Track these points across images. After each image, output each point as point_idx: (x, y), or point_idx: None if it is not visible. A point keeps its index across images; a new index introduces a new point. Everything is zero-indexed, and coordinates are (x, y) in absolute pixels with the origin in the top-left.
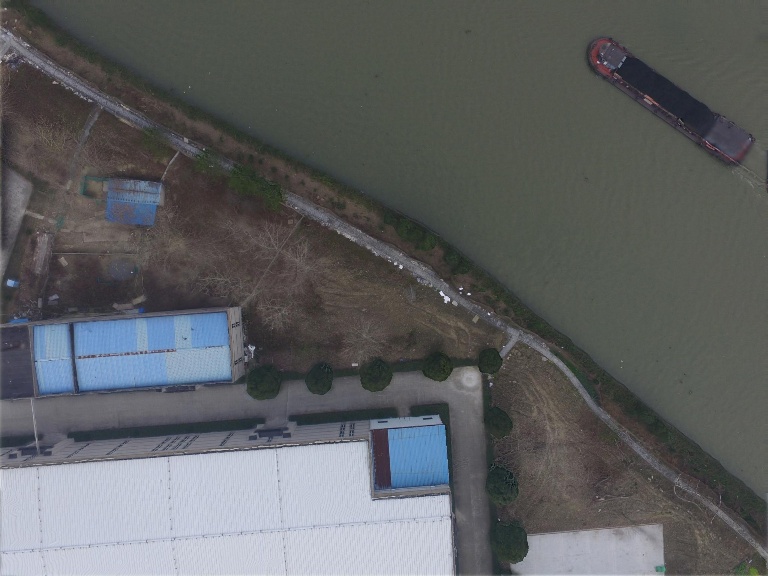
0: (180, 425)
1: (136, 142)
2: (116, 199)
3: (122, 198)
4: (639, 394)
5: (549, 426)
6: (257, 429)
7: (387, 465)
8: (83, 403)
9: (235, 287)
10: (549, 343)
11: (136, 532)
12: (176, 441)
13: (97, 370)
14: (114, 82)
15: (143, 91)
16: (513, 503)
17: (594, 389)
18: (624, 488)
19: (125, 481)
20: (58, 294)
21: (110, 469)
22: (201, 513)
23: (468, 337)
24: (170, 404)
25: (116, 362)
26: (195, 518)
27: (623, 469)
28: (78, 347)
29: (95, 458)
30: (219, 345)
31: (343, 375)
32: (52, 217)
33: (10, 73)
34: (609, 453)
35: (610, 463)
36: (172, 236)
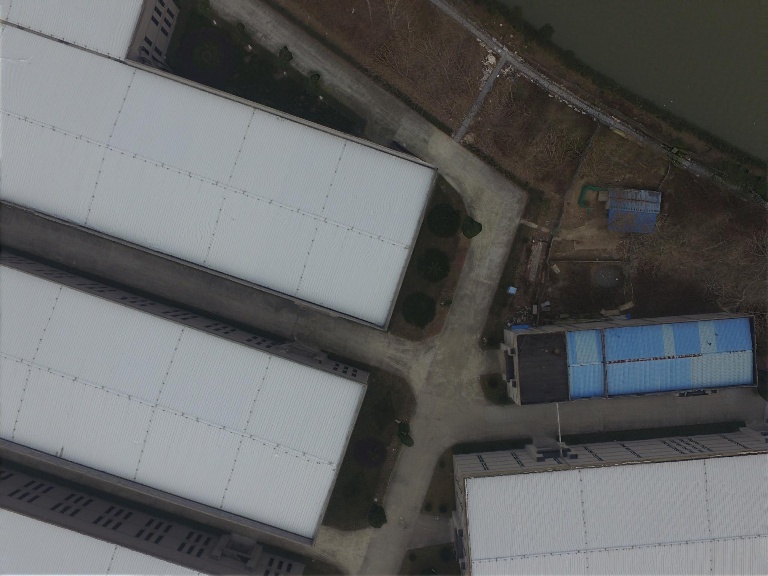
0: (664, 428)
1: (634, 153)
2: (619, 208)
3: (625, 207)
4: None
5: None
6: (764, 432)
7: None
8: (570, 407)
9: (718, 293)
10: None
11: (676, 533)
12: (682, 444)
13: (625, 375)
14: (606, 95)
15: (633, 103)
16: None
17: None
18: None
19: (664, 483)
20: (550, 301)
21: (649, 471)
22: (737, 514)
23: None
24: (654, 408)
25: (644, 367)
26: (732, 519)
27: None
28: (608, 352)
29: (635, 461)
30: (742, 350)
31: None
32: (545, 226)
33: (511, 87)
34: None
35: None
36: (663, 244)
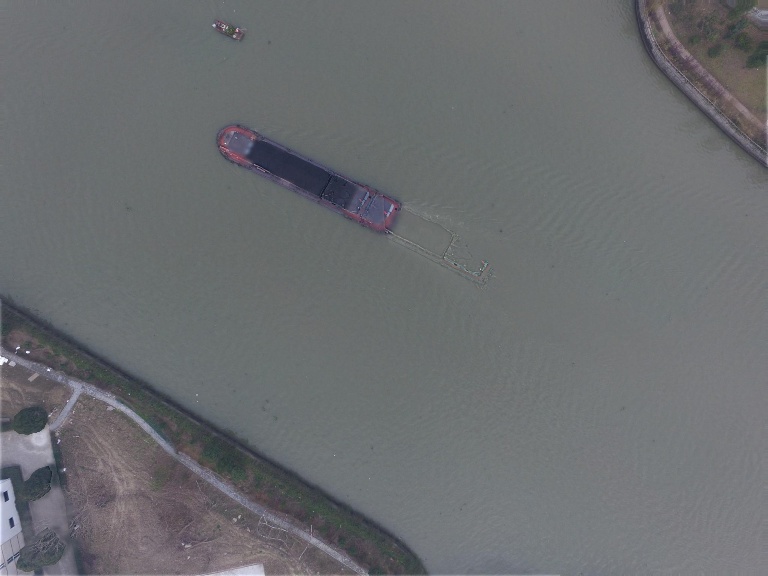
0: None
1: None
2: None
3: None
4: (229, 430)
5: (117, 477)
6: None
7: None
8: None
9: None
10: (106, 392)
11: None
12: None
13: None
14: None
15: None
16: (98, 560)
17: None
18: (207, 532)
19: None
20: None
21: None
22: None
23: (22, 397)
24: None
25: None
26: None
27: (204, 512)
28: None
29: None
30: None
31: None
32: None
33: None
34: (190, 497)
35: (193, 507)
36: None
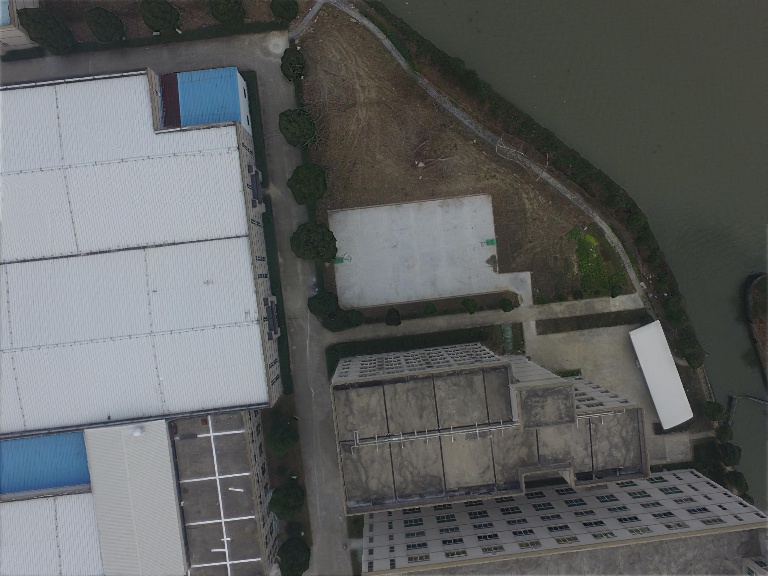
0: None
1: None
2: None
3: None
4: None
5: (359, 85)
6: None
7: (177, 108)
8: None
9: None
10: None
11: None
12: None
13: None
14: None
15: None
16: (328, 172)
17: (407, 50)
18: (443, 150)
19: None
20: None
21: None
22: None
23: None
24: None
25: None
26: None
27: (442, 131)
28: None
29: None
30: None
31: (144, 44)
32: None
33: None
34: (427, 117)
35: (429, 127)
36: None
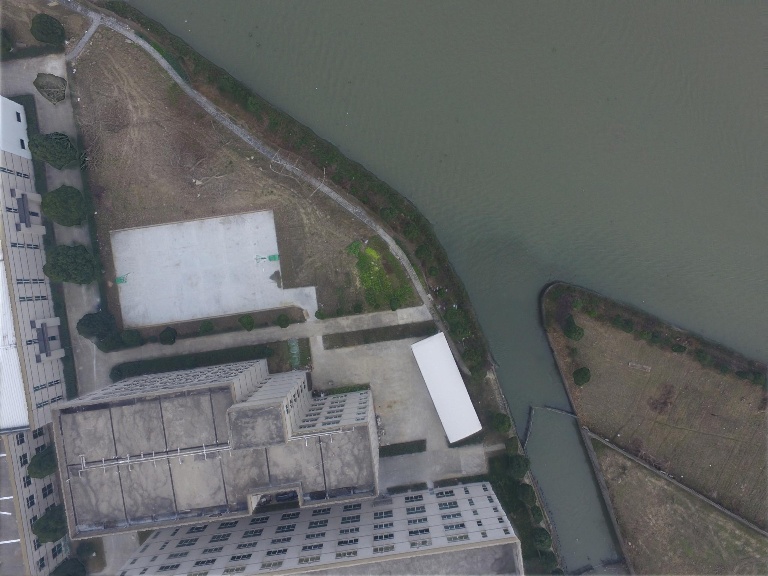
0: None
1: None
2: None
3: None
4: (246, 82)
5: (131, 105)
6: None
7: None
8: None
9: None
10: (125, 20)
11: None
12: None
13: None
14: None
15: None
16: (107, 193)
17: (183, 69)
18: (219, 167)
19: None
20: None
21: None
22: None
23: None
24: None
25: None
26: None
27: (217, 148)
28: None
29: None
30: None
31: None
32: None
33: None
34: (204, 135)
35: (206, 145)
36: None
